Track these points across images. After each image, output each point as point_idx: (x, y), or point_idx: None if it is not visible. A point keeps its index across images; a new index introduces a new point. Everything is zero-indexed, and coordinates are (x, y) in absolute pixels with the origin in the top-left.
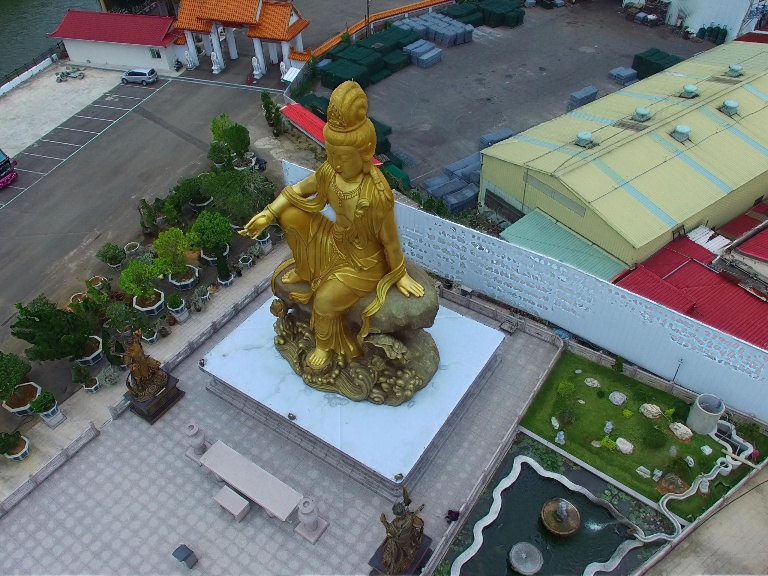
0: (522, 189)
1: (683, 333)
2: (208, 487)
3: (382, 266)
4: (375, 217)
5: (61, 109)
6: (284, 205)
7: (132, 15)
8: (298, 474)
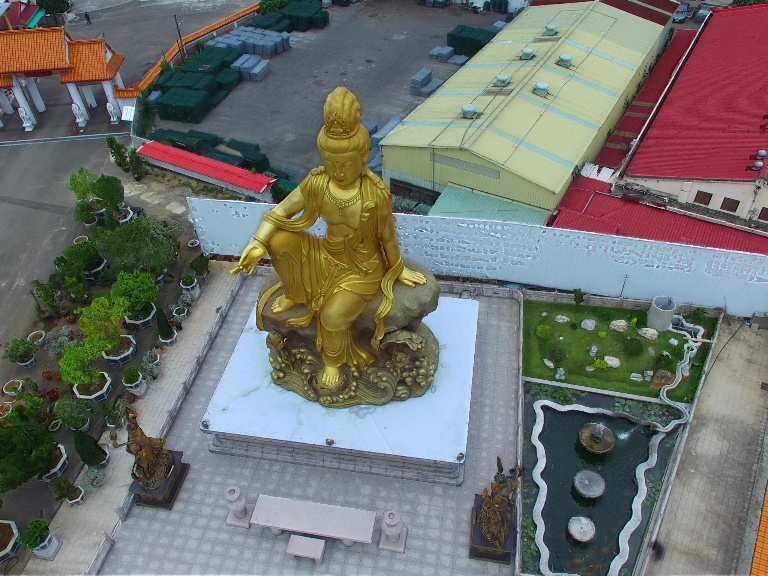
0: (430, 169)
1: (624, 252)
2: (269, 546)
3: (382, 265)
4: (380, 216)
5: None
6: (271, 231)
7: None
8: (352, 496)
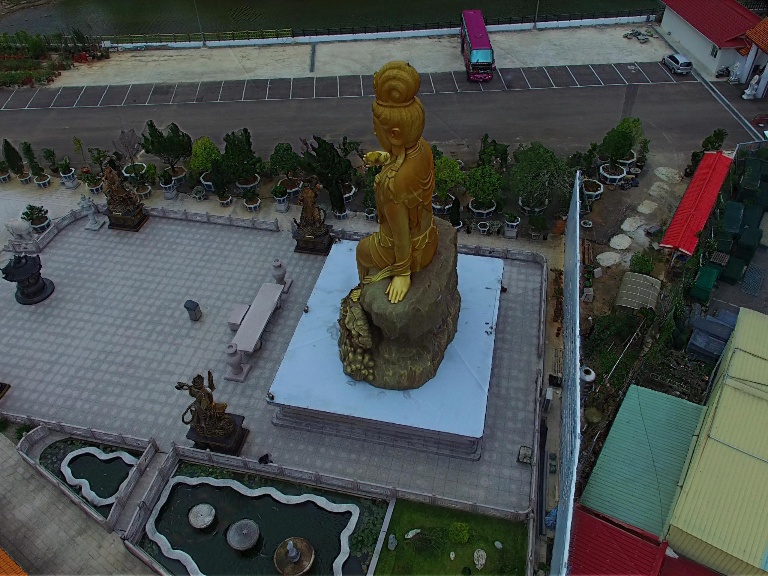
0: None
1: None
2: None
3: None
4: None
5: (591, 55)
6: None
7: (733, 7)
8: (281, 347)
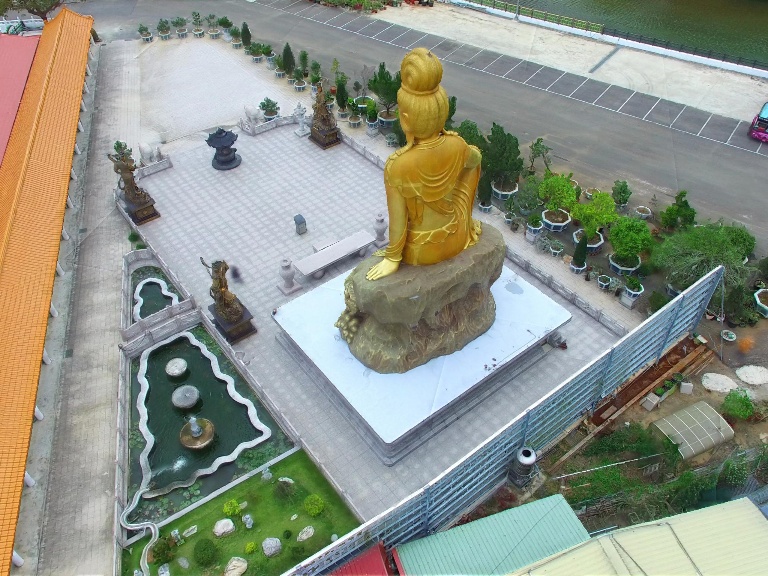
0: None
1: None
2: None
3: None
4: None
5: None
6: None
7: None
8: None
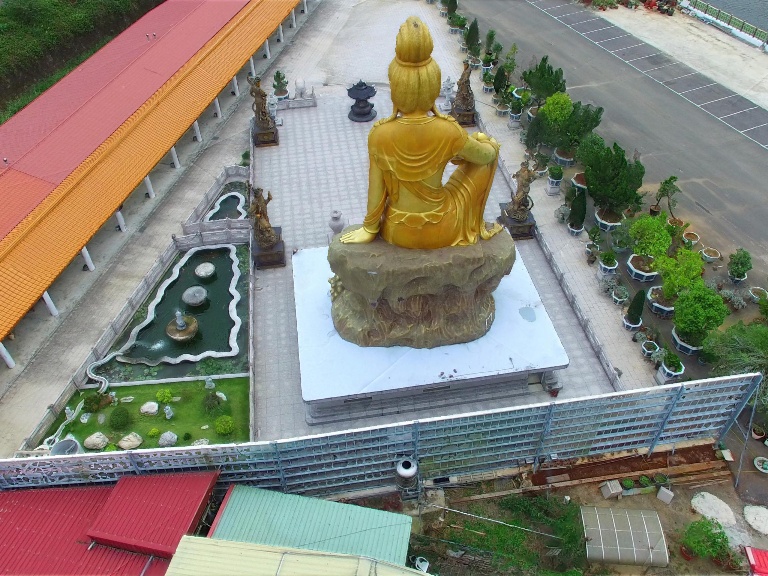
0: None
1: None
2: None
3: None
4: None
5: None
6: None
7: None
8: None
